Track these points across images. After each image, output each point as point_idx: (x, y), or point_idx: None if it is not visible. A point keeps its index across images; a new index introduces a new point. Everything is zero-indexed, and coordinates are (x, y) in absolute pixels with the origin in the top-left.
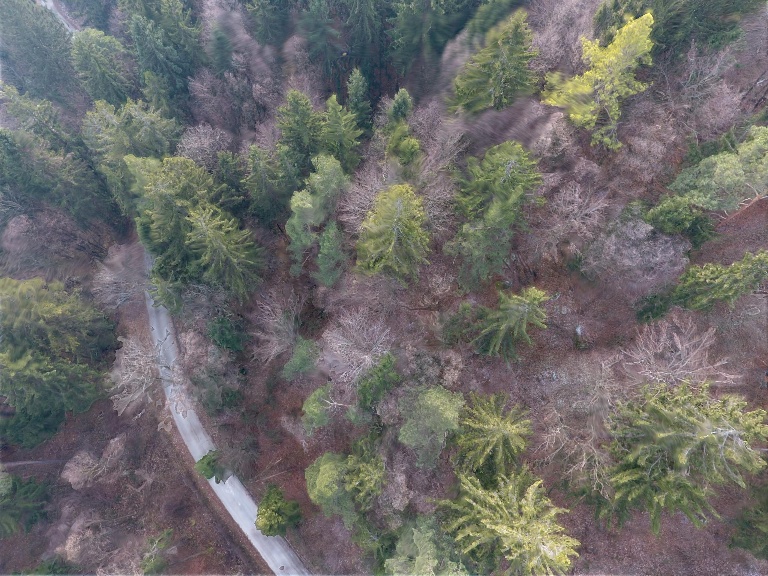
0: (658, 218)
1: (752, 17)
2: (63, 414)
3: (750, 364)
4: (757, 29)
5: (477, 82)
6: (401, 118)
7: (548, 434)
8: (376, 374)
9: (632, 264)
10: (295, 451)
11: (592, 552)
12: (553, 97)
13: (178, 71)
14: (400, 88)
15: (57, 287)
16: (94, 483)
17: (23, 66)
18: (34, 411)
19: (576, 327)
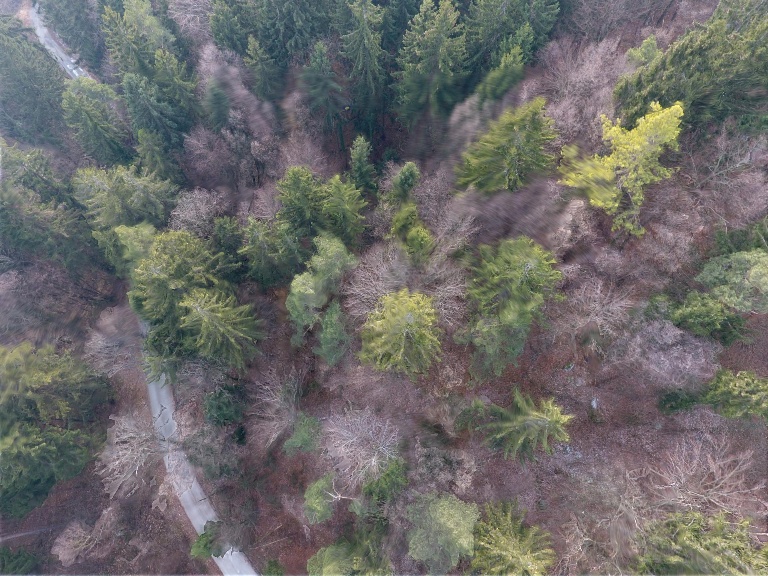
0: (686, 318)
1: None
2: (54, 479)
3: None
4: None
5: (490, 161)
6: (408, 188)
7: (570, 555)
8: (383, 478)
9: (660, 371)
10: (296, 517)
11: None
12: (571, 177)
13: (173, 126)
14: (405, 146)
15: (47, 351)
16: (86, 558)
17: (14, 106)
18: (23, 483)
19: (591, 400)
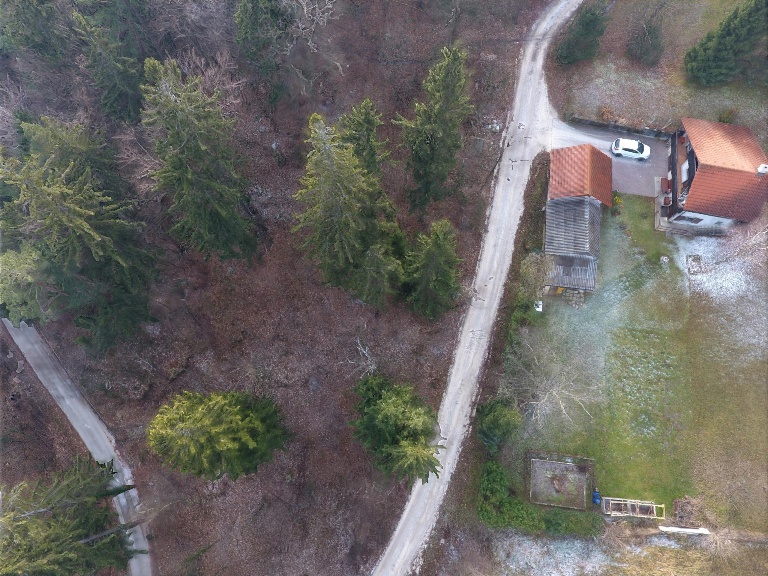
0: None
1: None
2: None
3: None
4: None
5: None
6: None
7: (123, 155)
8: None
9: (194, 17)
10: None
11: (284, 339)
12: None
13: None
14: None
15: None
16: None
17: None
18: None
19: (272, 143)
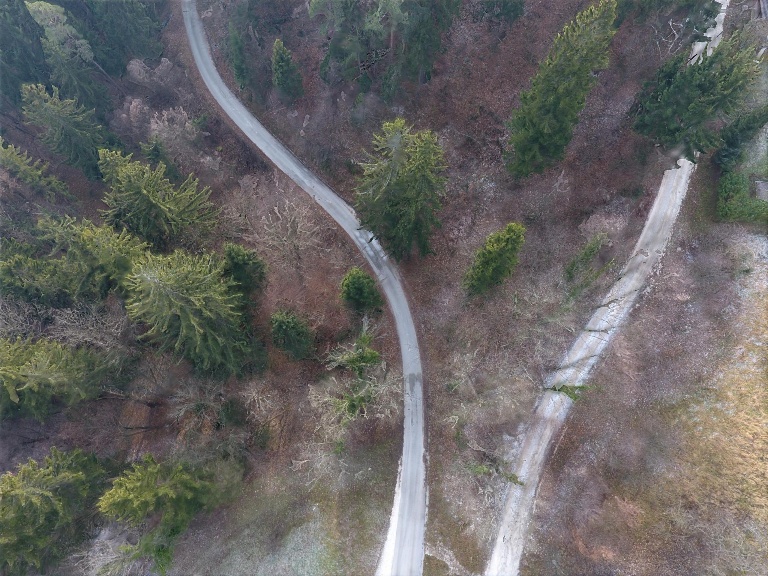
0: None
1: None
2: None
3: None
4: None
5: None
6: None
7: None
8: None
9: None
10: None
11: None
12: None
13: None
14: None
15: None
16: (150, 78)
17: None
18: (107, 26)
19: None
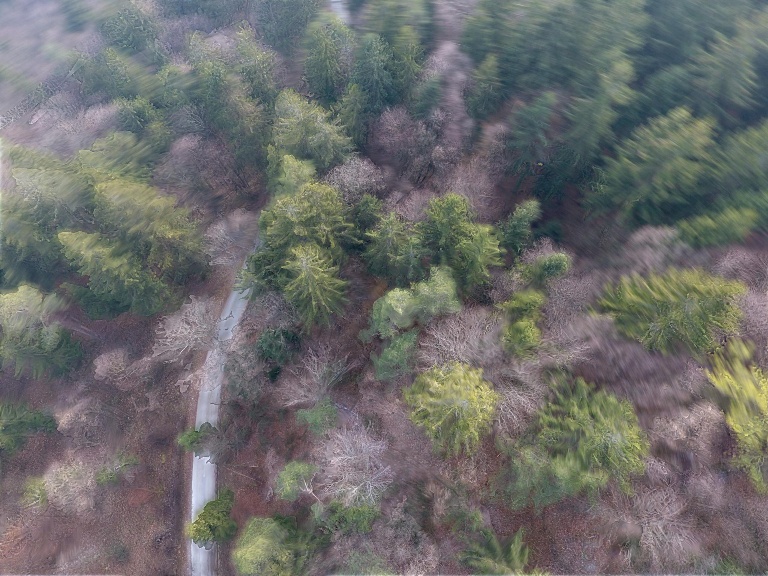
0: None
1: None
2: (129, 308)
3: None
4: None
5: (641, 305)
6: (546, 274)
7: None
8: (354, 509)
9: None
10: None
11: None
12: (716, 373)
13: (383, 95)
14: (571, 230)
15: (183, 212)
16: (111, 383)
17: (280, 5)
18: None
19: None
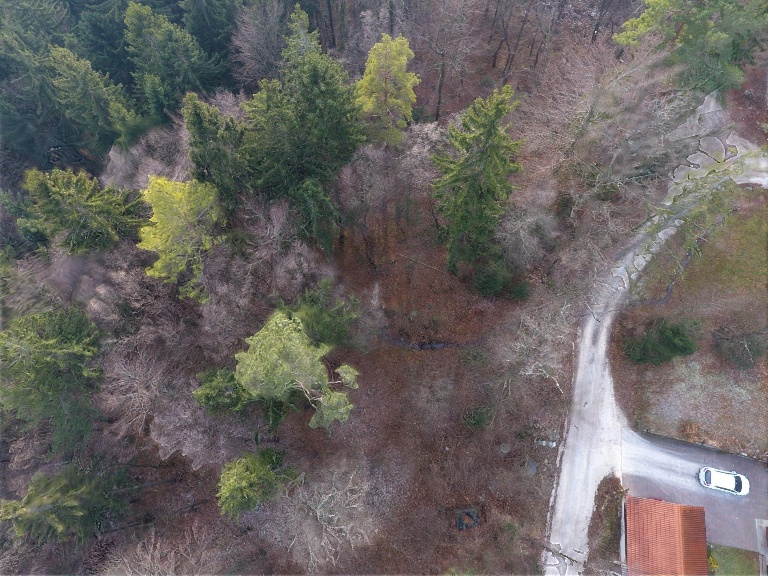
0: None
1: (345, 160)
2: None
3: (452, 501)
4: (342, 177)
5: None
6: (44, 242)
7: None
8: None
9: (162, 457)
10: None
11: None
12: None
13: None
14: None
15: None
16: None
17: None
18: None
19: None
